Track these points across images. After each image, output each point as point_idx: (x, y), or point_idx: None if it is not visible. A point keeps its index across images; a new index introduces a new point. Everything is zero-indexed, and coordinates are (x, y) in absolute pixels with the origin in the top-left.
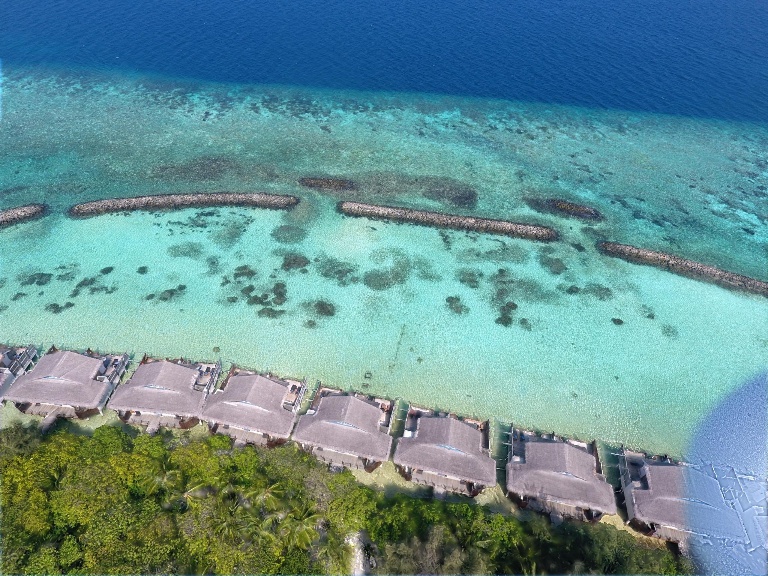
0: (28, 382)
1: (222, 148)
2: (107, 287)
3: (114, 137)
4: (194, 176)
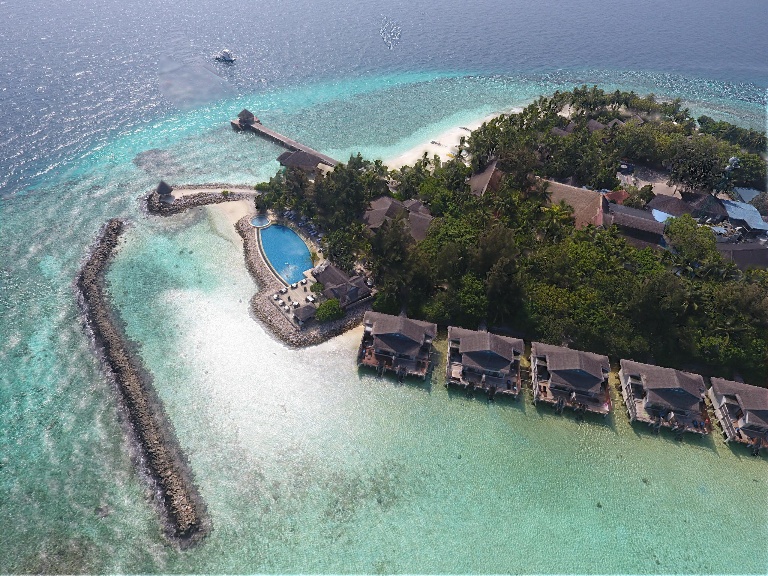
0: None
1: None
2: None
3: None
4: None
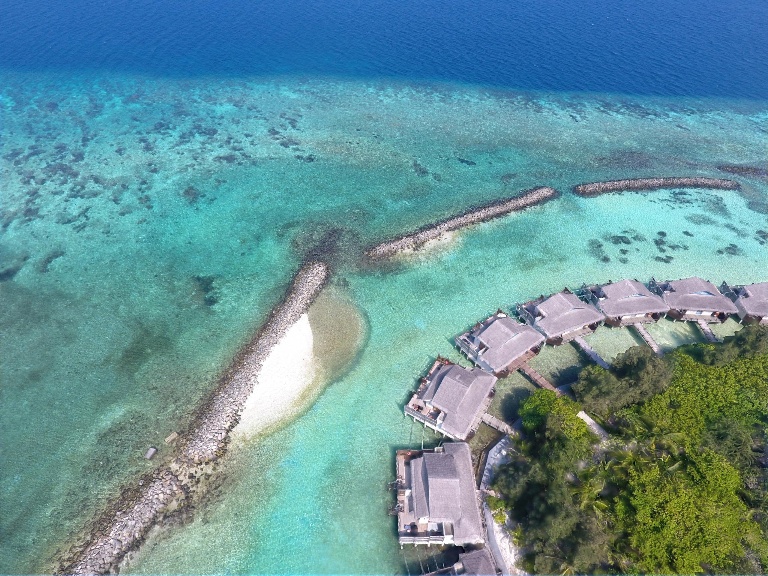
0: (760, 302)
1: (622, 143)
2: (679, 245)
3: (526, 135)
4: (631, 165)
